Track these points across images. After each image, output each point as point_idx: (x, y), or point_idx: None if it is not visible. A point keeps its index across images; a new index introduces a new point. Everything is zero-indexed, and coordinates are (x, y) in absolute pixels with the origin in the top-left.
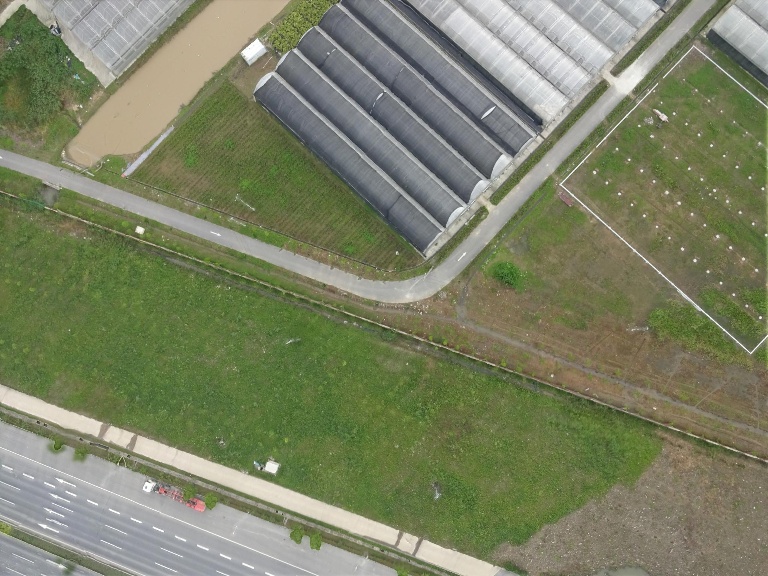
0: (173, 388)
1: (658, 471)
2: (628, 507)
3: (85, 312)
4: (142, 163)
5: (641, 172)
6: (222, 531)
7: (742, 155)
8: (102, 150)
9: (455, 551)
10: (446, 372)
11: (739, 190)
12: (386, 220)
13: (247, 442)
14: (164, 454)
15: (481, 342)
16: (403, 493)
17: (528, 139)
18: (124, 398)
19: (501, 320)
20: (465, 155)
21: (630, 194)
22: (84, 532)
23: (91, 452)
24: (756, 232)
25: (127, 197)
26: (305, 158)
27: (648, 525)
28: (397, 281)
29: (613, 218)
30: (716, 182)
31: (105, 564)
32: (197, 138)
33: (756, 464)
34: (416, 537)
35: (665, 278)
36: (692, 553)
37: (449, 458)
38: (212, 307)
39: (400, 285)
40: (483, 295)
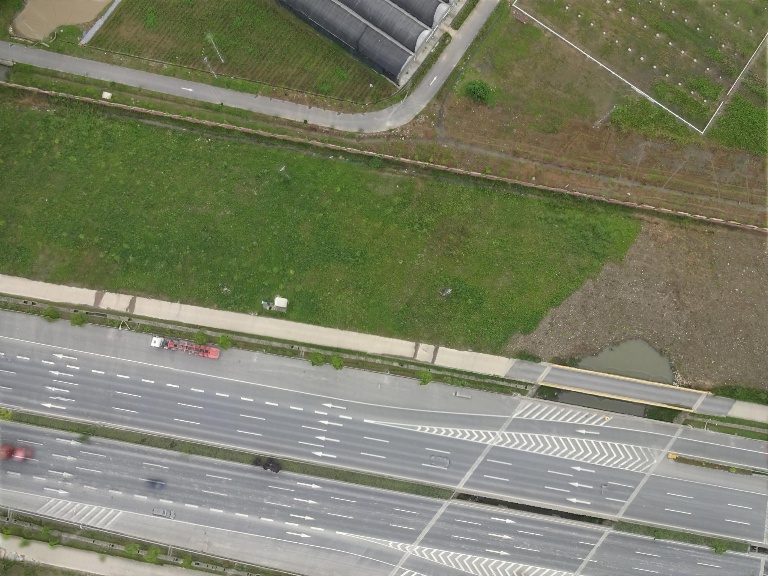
0: (168, 241)
1: (641, 246)
2: (621, 281)
3: (61, 180)
4: (99, 30)
5: None
6: (240, 375)
7: None
8: (53, 22)
9: (471, 352)
10: (436, 188)
11: None
12: (356, 54)
13: (252, 284)
14: (167, 311)
15: (464, 157)
16: (414, 305)
17: None
18: (116, 261)
19: (479, 134)
20: None
21: (576, 7)
22: (93, 403)
23: (89, 321)
24: (689, 27)
25: (88, 64)
26: (267, 6)
27: (641, 295)
28: (375, 111)
29: (565, 30)
30: None
31: (122, 429)
32: None
33: (723, 228)
34: (432, 346)
35: (619, 77)
36: (683, 313)
37: (452, 264)
38: (195, 159)
39: (379, 115)
40: (458, 114)
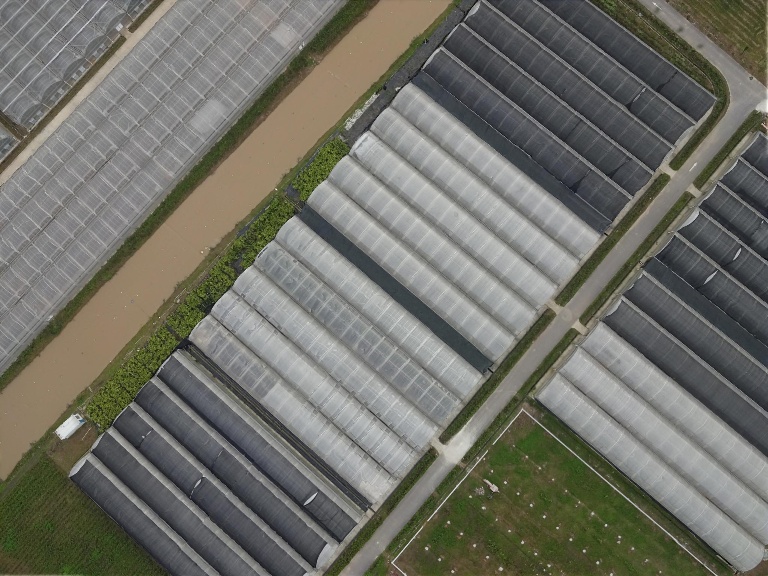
0: None
1: None
2: None
3: None
4: None
5: (474, 547)
6: None
7: (575, 527)
8: None
9: None
10: None
11: (574, 565)
12: None
13: None
14: None
15: None
16: None
17: (351, 529)
18: None
19: None
20: (289, 542)
21: (463, 571)
22: None
23: None
24: None
25: None
26: (128, 540)
27: None
28: None
29: None
30: (550, 557)
31: None
32: (15, 519)
33: None
34: None
35: None
36: None
37: None
38: None
39: None
40: None
